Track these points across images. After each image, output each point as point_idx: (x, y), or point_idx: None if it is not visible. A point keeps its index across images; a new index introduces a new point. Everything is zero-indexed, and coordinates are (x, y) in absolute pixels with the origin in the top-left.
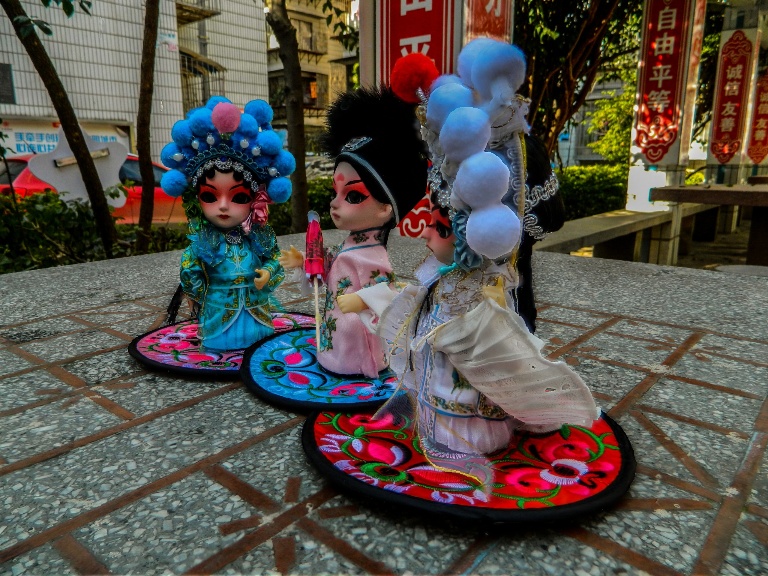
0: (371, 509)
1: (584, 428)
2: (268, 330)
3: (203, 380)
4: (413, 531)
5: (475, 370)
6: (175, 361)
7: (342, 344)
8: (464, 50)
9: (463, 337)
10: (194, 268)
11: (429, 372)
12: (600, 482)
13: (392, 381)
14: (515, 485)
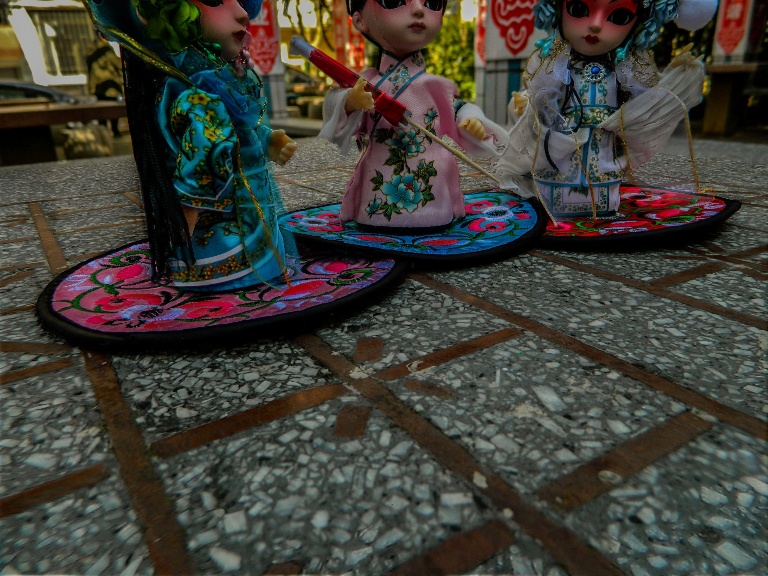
0: (704, 240)
1: None
2: None
3: (388, 293)
4: (725, 234)
5: (657, 128)
6: (323, 296)
7: (446, 188)
8: None
9: (655, 103)
10: (235, 137)
11: (595, 156)
12: (658, 191)
13: (479, 211)
14: (671, 203)
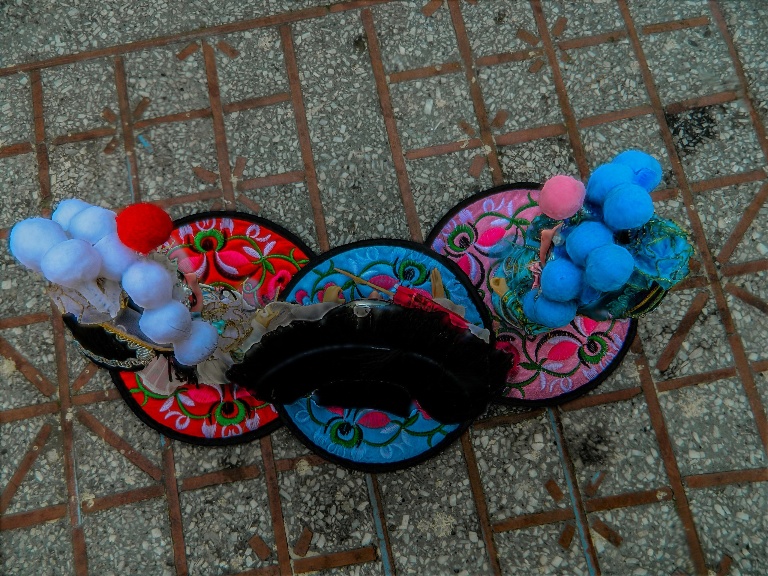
0: None
1: (161, 399)
2: (499, 308)
3: None
4: None
5: None
6: (487, 210)
7: None
8: (74, 240)
9: None
10: None
11: None
12: None
13: None
14: None
